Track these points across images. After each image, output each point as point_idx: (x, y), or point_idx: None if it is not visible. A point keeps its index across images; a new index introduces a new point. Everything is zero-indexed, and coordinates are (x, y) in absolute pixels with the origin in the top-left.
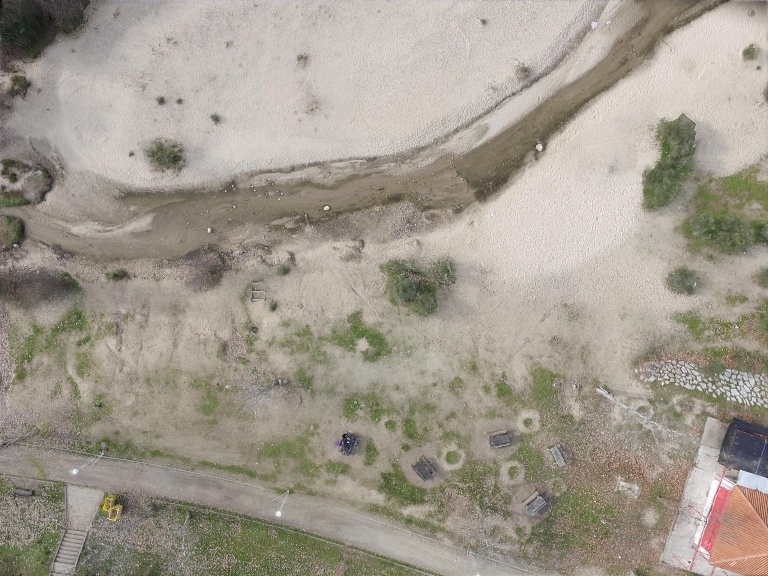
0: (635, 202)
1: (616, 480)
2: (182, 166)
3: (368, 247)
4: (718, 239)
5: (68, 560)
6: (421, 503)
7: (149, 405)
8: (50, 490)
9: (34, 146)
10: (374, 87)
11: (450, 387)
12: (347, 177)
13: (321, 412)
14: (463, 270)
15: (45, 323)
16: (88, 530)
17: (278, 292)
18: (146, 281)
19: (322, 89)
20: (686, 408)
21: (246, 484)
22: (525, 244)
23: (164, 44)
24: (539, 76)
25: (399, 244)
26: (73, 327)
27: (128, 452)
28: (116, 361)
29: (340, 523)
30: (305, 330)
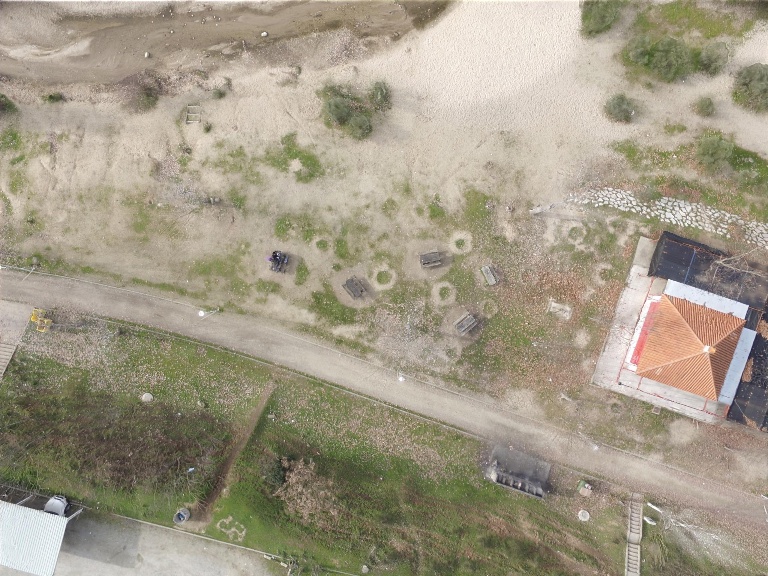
0: (573, 28)
1: (548, 301)
2: None
3: (305, 73)
4: (654, 60)
5: None
6: (351, 323)
7: (81, 222)
8: None
9: None
10: None
11: (383, 209)
12: (285, 3)
13: (253, 231)
14: (399, 96)
15: None
16: (17, 344)
17: (213, 115)
18: (82, 103)
19: None
20: (619, 229)
21: (176, 302)
22: (462, 70)
23: None
24: None
25: (336, 70)
26: (8, 147)
27: (59, 268)
28: (49, 179)
29: (270, 342)
30: (239, 151)
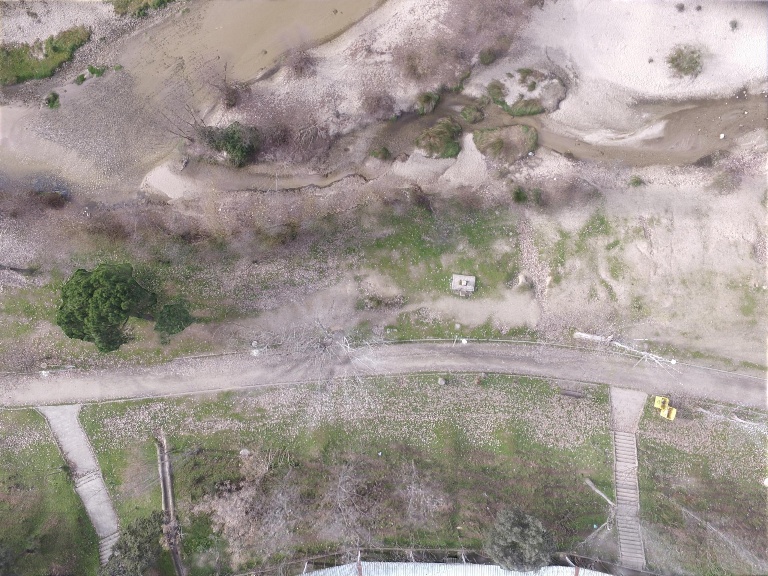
0: None
1: None
2: (699, 72)
3: None
4: None
5: (628, 460)
6: None
7: (687, 306)
8: (595, 392)
9: (549, 55)
10: None
11: None
12: None
13: None
14: None
15: (570, 228)
16: (635, 431)
17: None
18: (665, 186)
19: None
20: None
21: None
22: None
23: None
24: None
25: None
26: (598, 232)
27: (669, 353)
28: (649, 264)
29: None
30: None
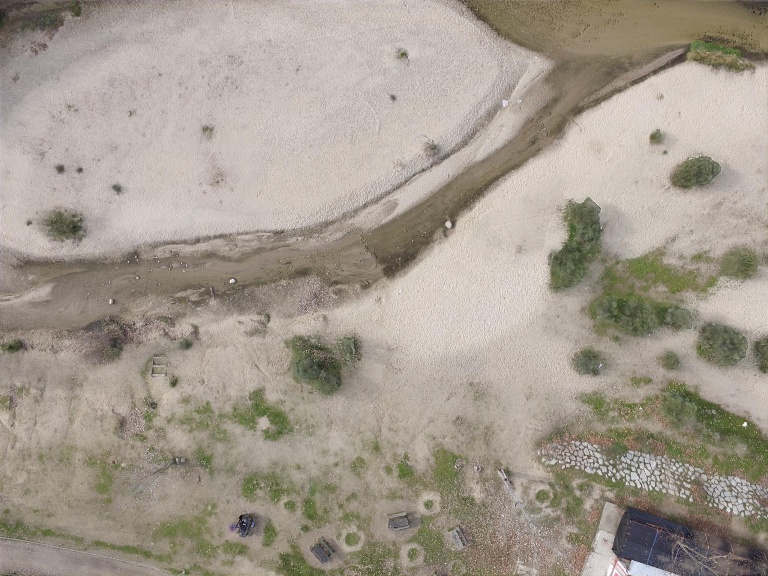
0: (542, 282)
1: (515, 563)
2: (83, 236)
3: (274, 321)
4: (621, 323)
5: None
6: None
7: (41, 483)
8: None
9: None
10: (281, 160)
11: (352, 467)
12: (254, 250)
13: (219, 492)
14: (369, 347)
15: None
16: None
17: (179, 367)
18: (43, 353)
19: (228, 161)
20: (585, 492)
21: (140, 565)
22: (432, 322)
23: (65, 111)
24: (449, 153)
25: (305, 319)
26: None
27: (18, 531)
28: (8, 437)
29: None
30: (205, 407)
